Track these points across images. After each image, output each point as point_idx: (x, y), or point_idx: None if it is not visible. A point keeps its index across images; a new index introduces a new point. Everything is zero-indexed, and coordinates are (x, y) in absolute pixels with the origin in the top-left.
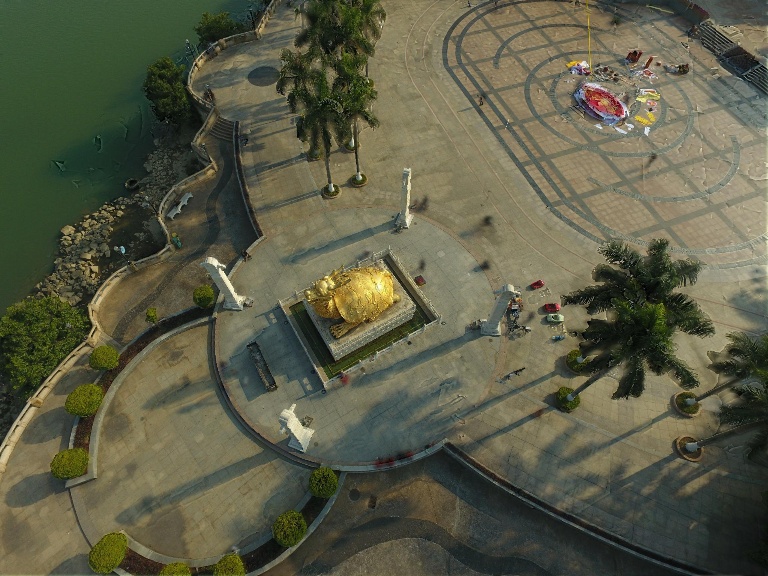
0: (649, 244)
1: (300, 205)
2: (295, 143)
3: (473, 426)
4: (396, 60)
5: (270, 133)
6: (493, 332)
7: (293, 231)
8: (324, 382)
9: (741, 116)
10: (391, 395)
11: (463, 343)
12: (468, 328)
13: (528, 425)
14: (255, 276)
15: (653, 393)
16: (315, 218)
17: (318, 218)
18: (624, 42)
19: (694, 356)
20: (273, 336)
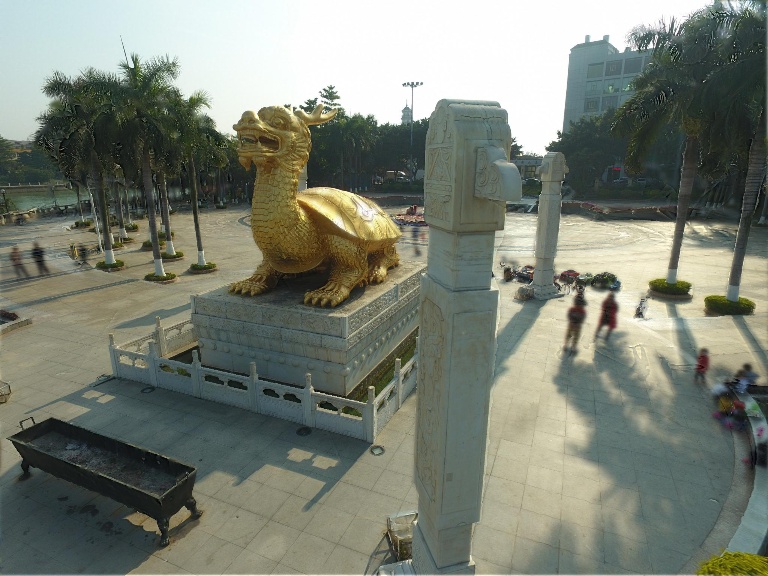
0: (634, 84)
1: (103, 291)
2: (66, 264)
3: (718, 364)
4: (192, 230)
5: (8, 265)
6: (553, 292)
7: (100, 307)
8: (372, 395)
9: (515, 216)
10: (536, 388)
11: (535, 310)
12: (518, 301)
13: (759, 335)
14: (7, 363)
15: (763, 287)
16: (144, 292)
17: (151, 291)
18: (395, 212)
19: (725, 268)
20: (114, 421)
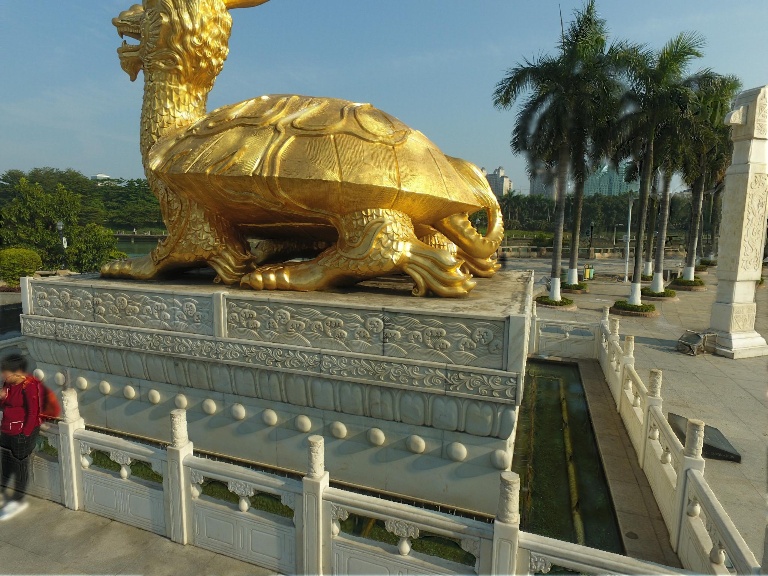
0: None
1: None
2: (547, 278)
3: None
4: None
5: None
6: None
7: None
8: None
9: None
10: None
11: None
12: None
13: None
14: None
15: None
16: None
17: None
18: None
19: None
20: None
